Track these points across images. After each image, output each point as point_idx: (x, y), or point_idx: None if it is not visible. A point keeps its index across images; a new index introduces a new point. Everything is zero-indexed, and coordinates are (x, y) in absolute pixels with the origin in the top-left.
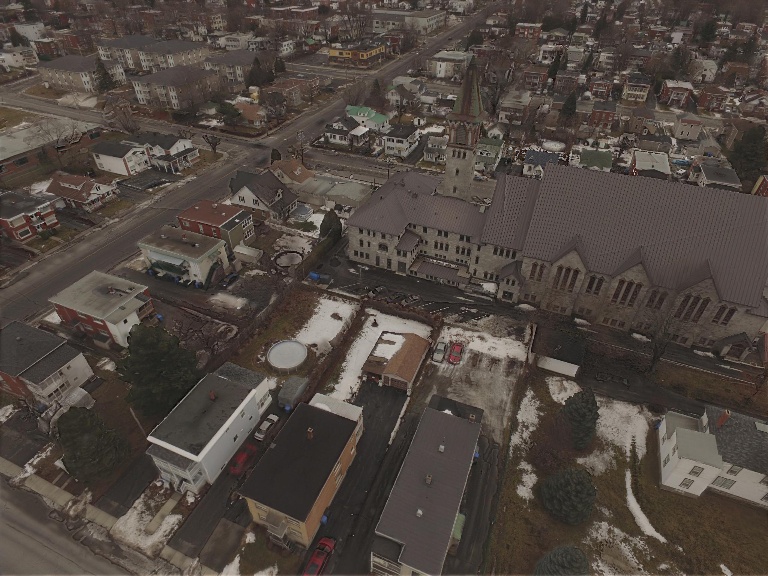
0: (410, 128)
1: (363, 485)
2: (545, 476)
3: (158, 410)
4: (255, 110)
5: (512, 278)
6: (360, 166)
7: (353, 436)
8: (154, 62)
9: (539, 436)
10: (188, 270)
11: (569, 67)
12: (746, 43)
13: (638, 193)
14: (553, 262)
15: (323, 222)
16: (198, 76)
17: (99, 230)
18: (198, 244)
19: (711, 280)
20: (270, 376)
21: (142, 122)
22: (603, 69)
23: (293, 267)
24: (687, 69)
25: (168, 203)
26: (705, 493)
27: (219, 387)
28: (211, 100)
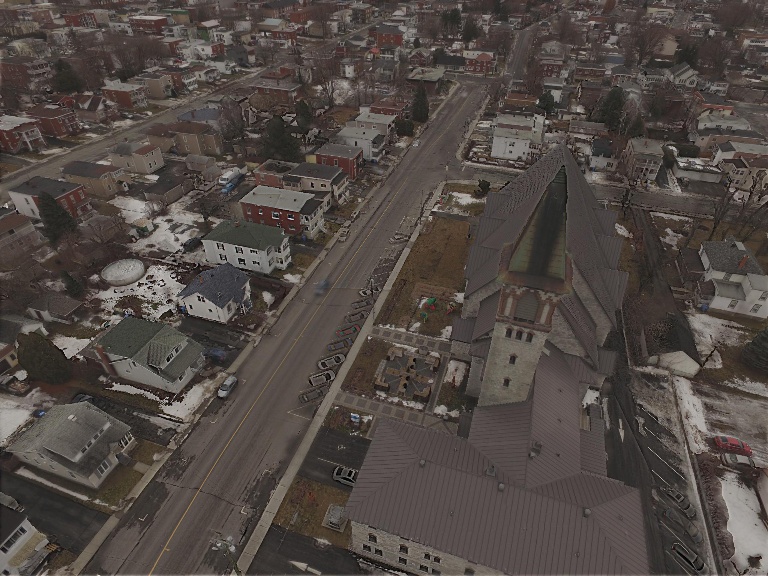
0: None
1: None
2: None
3: None
4: None
5: None
6: None
7: None
8: None
9: None
10: None
11: None
12: None
13: None
14: None
15: None
16: None
17: None
18: None
19: None
20: None
21: None
22: None
23: None
24: None
25: None
26: None
27: None
28: None
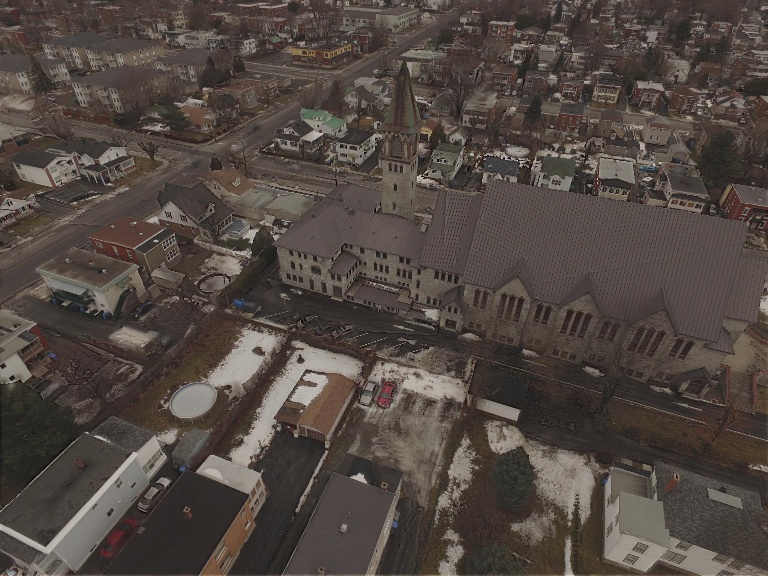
0: (365, 133)
1: (258, 567)
2: (473, 548)
3: (23, 478)
4: (202, 114)
5: (454, 306)
6: (310, 175)
7: (246, 510)
8: (103, 61)
9: (471, 496)
10: (94, 299)
11: (540, 67)
12: (719, 43)
13: (587, 213)
14: (495, 290)
15: (254, 241)
16: (143, 77)
17: (7, 251)
18: (105, 270)
19: (665, 312)
20: (170, 427)
21: (81, 127)
22: (575, 69)
23: (215, 293)
24: (659, 69)
25: (92, 218)
26: (653, 567)
27: (93, 451)
28: (158, 103)
